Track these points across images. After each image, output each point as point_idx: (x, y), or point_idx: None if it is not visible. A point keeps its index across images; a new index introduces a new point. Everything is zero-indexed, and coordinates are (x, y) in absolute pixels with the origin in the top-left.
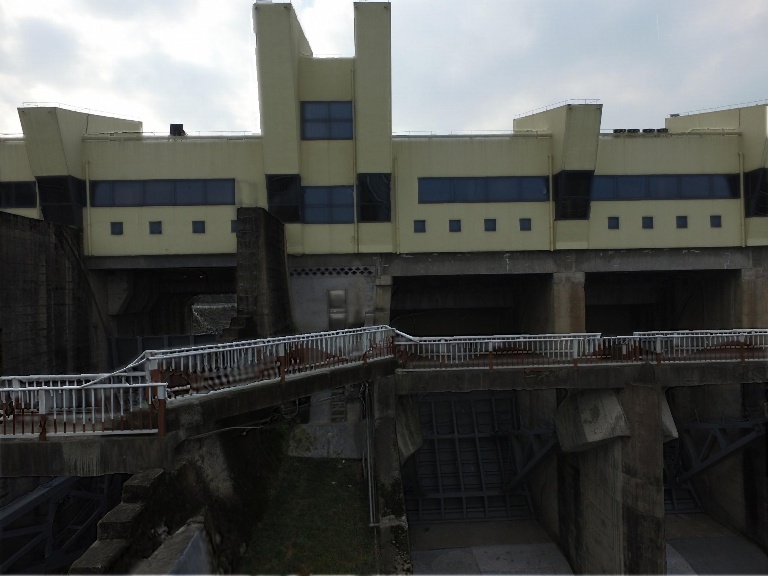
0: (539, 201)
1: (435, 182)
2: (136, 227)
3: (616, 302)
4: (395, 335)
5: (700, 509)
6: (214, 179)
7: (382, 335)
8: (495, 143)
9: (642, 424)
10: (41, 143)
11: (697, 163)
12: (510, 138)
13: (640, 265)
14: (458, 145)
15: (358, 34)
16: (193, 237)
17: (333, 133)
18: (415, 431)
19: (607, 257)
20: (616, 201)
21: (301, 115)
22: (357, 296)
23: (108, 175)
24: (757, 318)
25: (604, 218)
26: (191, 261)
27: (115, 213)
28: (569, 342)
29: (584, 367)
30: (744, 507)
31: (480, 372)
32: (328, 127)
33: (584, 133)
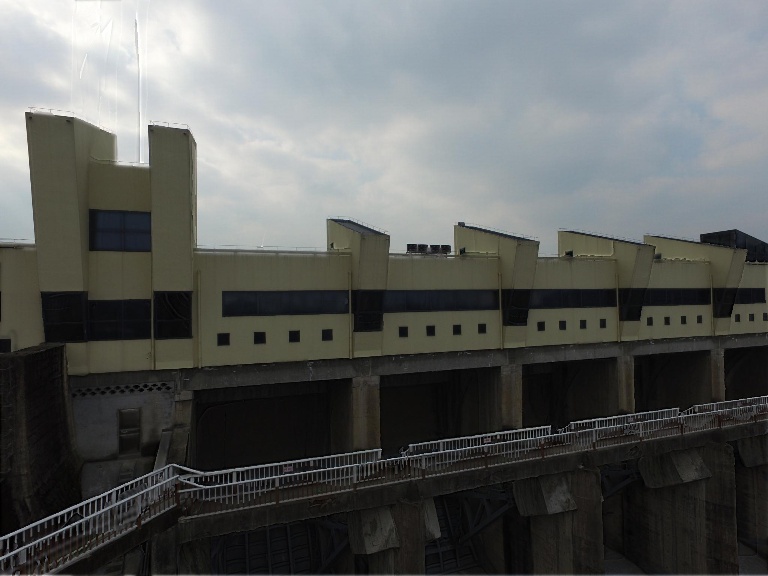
0: (340, 313)
1: (240, 295)
2: None
3: (416, 383)
4: (179, 482)
5: (477, 563)
6: None
7: (162, 488)
8: (300, 259)
9: (408, 537)
10: None
11: (468, 280)
12: (314, 255)
13: (425, 367)
14: (264, 260)
15: (155, 156)
16: None
17: (129, 244)
18: (203, 570)
19: (398, 361)
20: (406, 313)
21: (90, 224)
22: (153, 414)
23: None
24: (512, 405)
25: (396, 327)
26: None
27: None
28: (350, 469)
29: (362, 490)
30: (504, 563)
31: (266, 508)
32: (123, 238)
33: (376, 259)
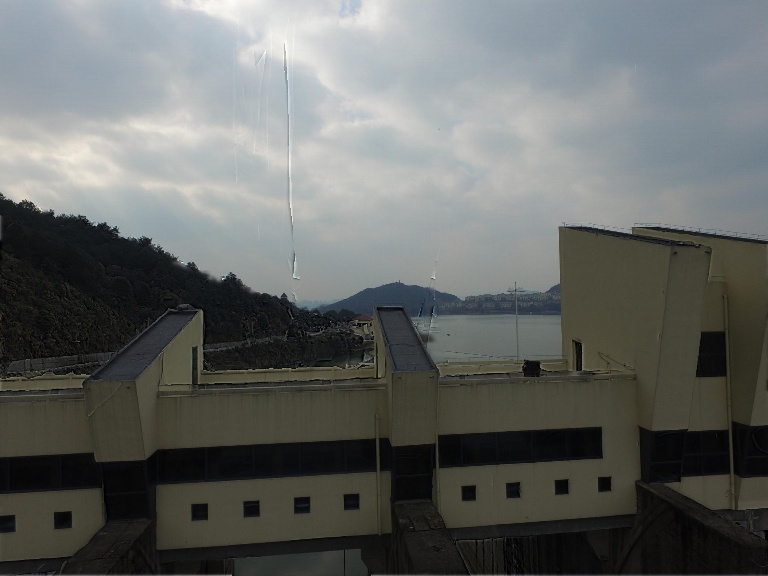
0: None
1: None
2: (491, 490)
3: None
4: None
5: None
6: (578, 428)
7: None
8: None
9: None
10: (411, 410)
11: None
12: None
13: None
14: None
15: None
16: (555, 499)
17: (704, 369)
18: None
19: None
20: None
21: None
22: None
23: (458, 428)
24: None
25: None
26: (550, 527)
27: (466, 474)
28: None
29: None
30: None
31: None
32: (699, 362)
33: None
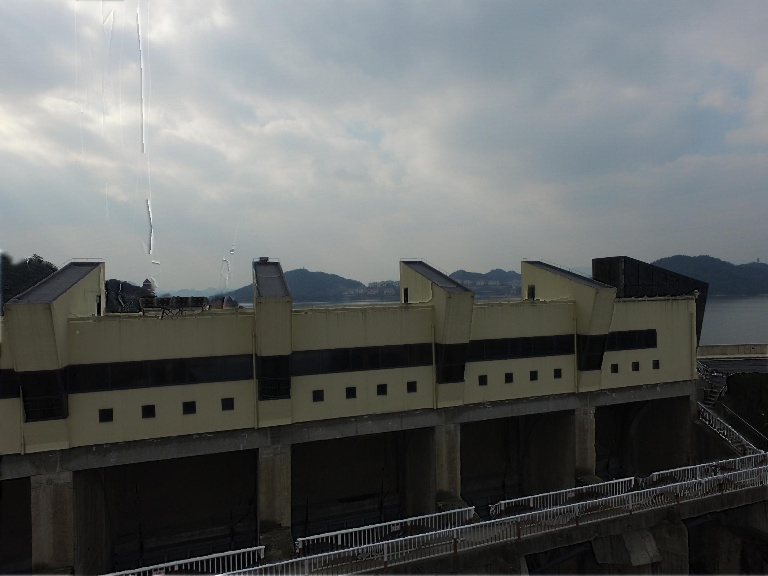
0: (7, 398)
1: None
2: None
3: None
4: None
5: None
6: None
7: None
8: None
9: None
10: None
11: (207, 345)
12: None
13: (143, 456)
14: None
15: None
16: None
17: None
18: None
19: (102, 451)
20: (109, 391)
21: None
22: None
23: None
24: (275, 495)
25: (94, 411)
26: None
27: None
28: None
29: None
30: None
31: None
32: None
33: (35, 333)
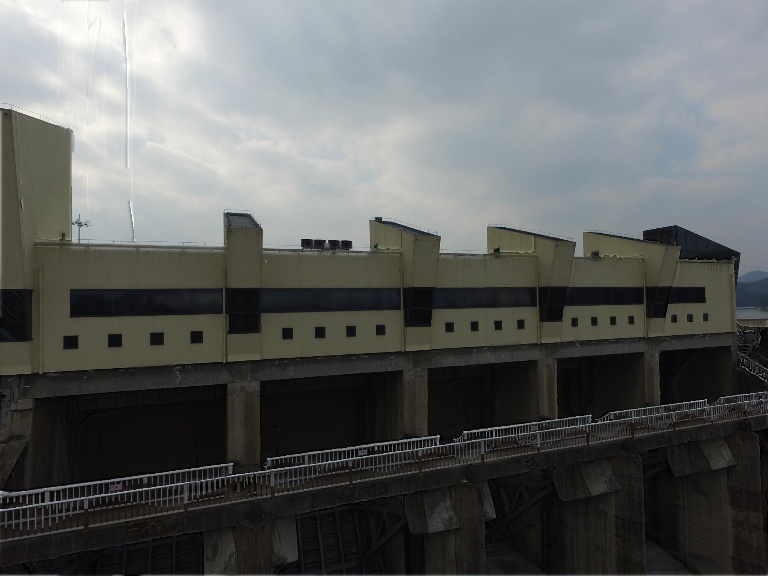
0: (212, 313)
1: (92, 294)
2: None
3: (327, 387)
4: None
5: None
6: None
7: None
8: (165, 255)
9: (245, 564)
10: None
11: (365, 278)
12: (182, 250)
13: (314, 371)
14: (121, 255)
15: None
16: None
17: None
18: None
19: (283, 365)
20: (291, 313)
21: None
22: None
23: None
24: (416, 412)
25: (279, 329)
26: None
27: None
28: (179, 487)
29: (195, 511)
30: None
31: (71, 534)
32: None
33: (248, 254)
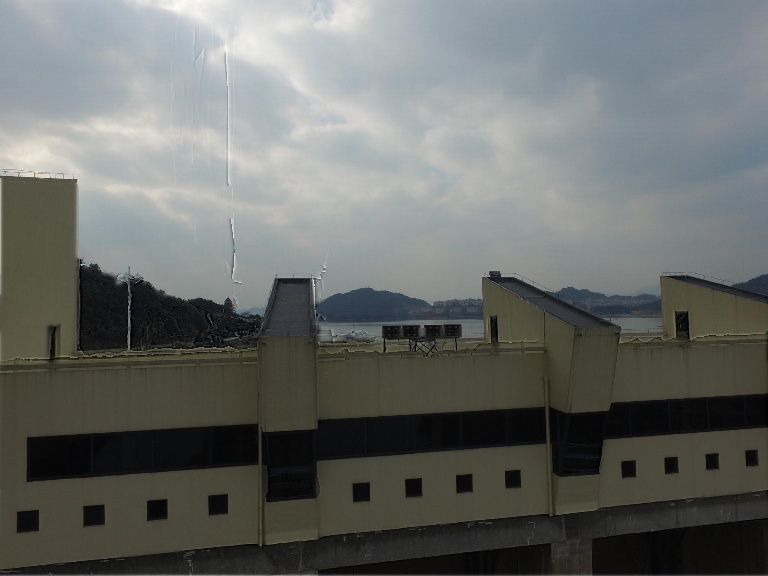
0: (242, 465)
1: (60, 443)
2: None
3: None
4: None
5: None
6: None
7: None
8: (170, 374)
9: None
10: None
11: (486, 394)
12: (196, 365)
13: (404, 551)
14: (104, 379)
15: None
16: None
17: None
18: None
19: (354, 543)
20: (366, 458)
21: None
22: None
23: None
24: None
25: (347, 485)
26: None
27: None
28: None
29: None
30: None
31: None
32: None
33: (292, 378)
